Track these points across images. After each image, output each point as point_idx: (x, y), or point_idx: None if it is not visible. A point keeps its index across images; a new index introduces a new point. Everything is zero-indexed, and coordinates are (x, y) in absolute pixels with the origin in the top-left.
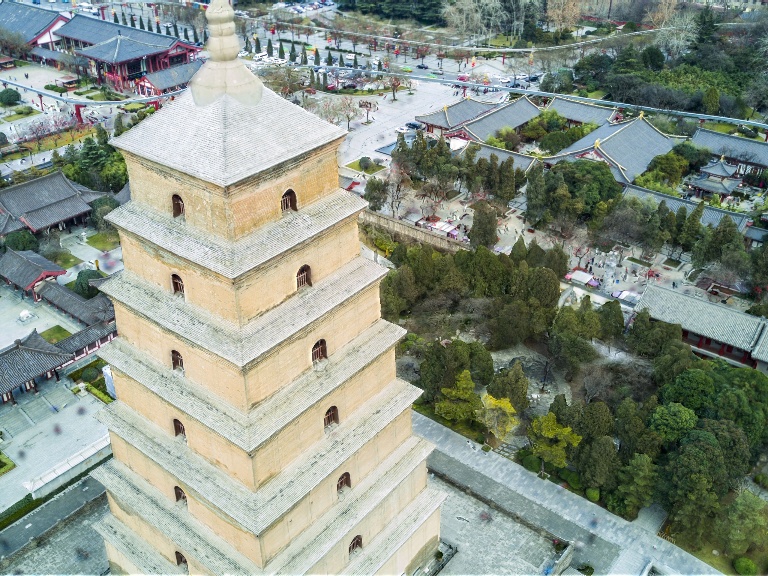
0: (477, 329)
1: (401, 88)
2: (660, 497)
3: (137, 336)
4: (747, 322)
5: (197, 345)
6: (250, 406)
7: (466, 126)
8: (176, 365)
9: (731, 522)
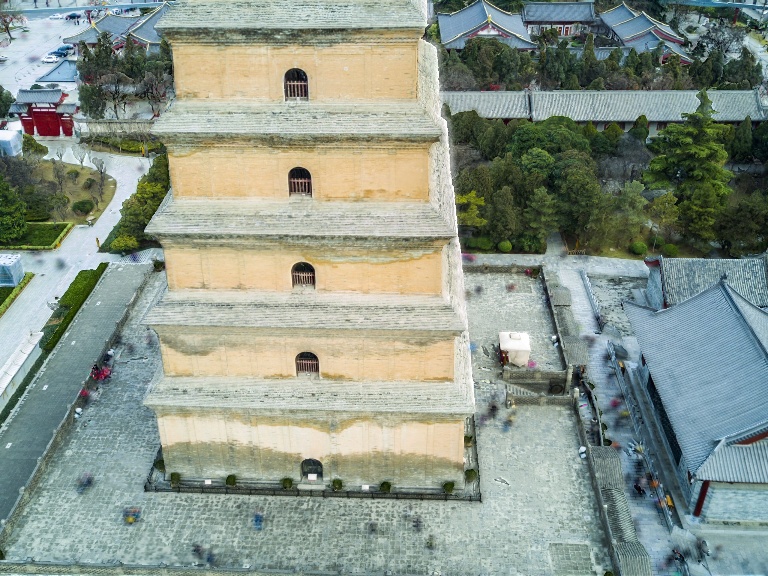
0: None
1: (9, 28)
2: (564, 219)
3: (218, 80)
4: (515, 98)
5: (346, 34)
6: None
7: (133, 33)
8: (285, 96)
9: (626, 211)
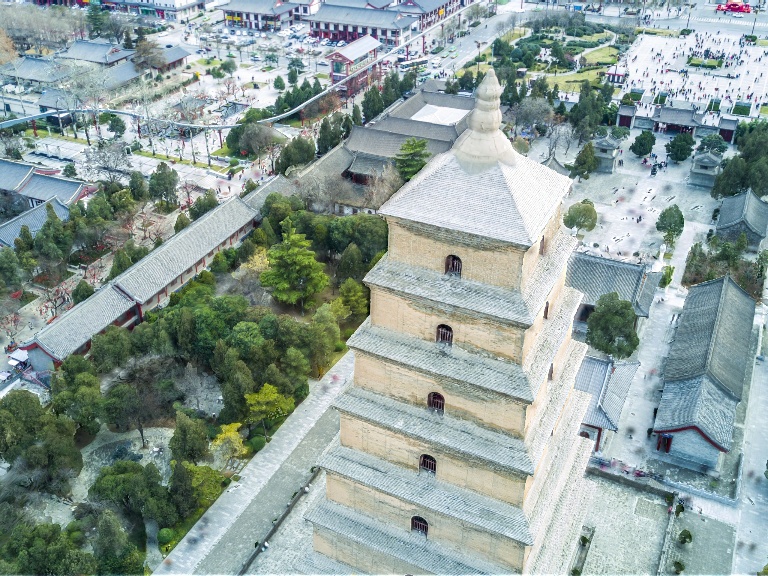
0: None
1: None
2: None
3: None
4: (108, 294)
5: None
6: None
7: None
8: None
9: (331, 328)
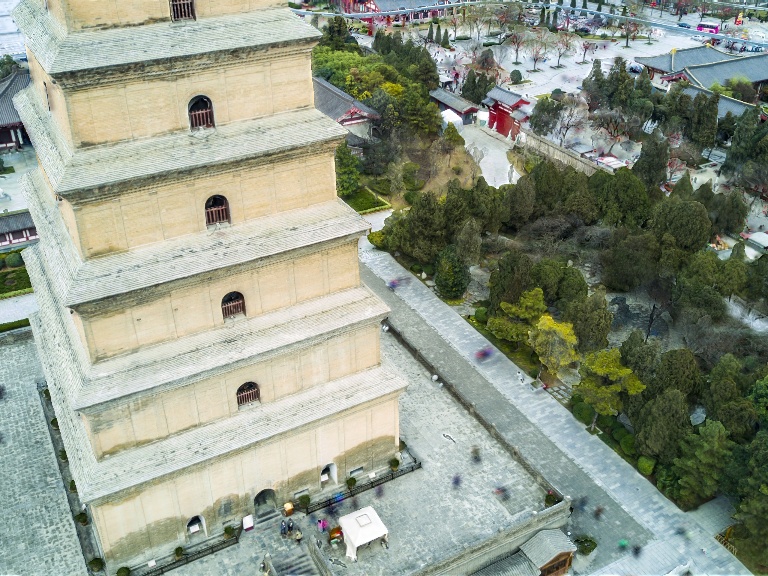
0: (589, 260)
1: (640, 37)
2: (728, 485)
3: None
4: None
5: None
6: (79, 144)
7: (688, 69)
8: None
9: None
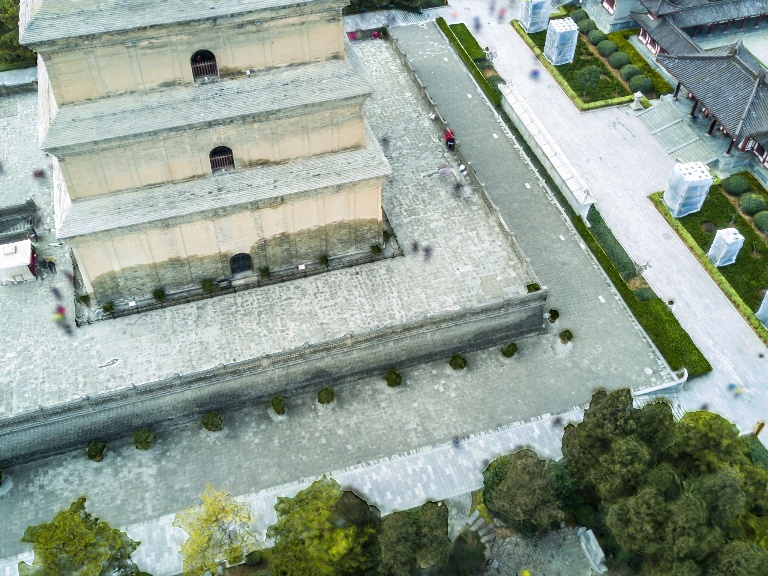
0: None
1: None
2: None
3: None
4: None
5: None
6: None
7: None
8: None
9: None
